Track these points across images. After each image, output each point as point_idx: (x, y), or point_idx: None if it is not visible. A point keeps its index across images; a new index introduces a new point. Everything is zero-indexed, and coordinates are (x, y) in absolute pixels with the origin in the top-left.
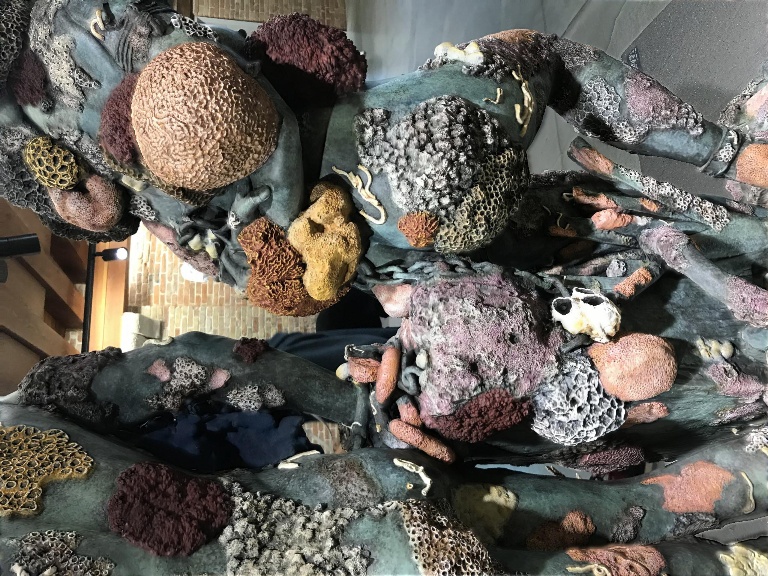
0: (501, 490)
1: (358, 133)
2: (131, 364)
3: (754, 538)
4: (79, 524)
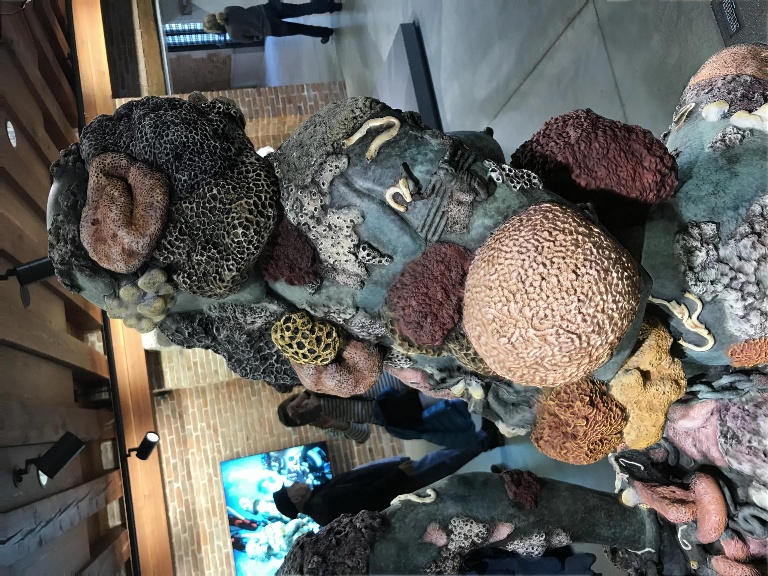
0: None
1: (684, 256)
2: (403, 535)
3: None
4: None
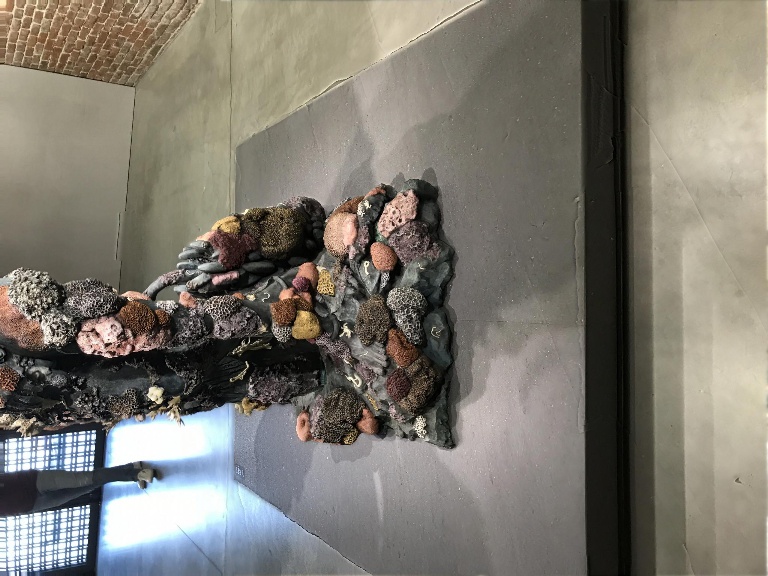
0: None
1: None
2: None
3: (402, 535)
4: None
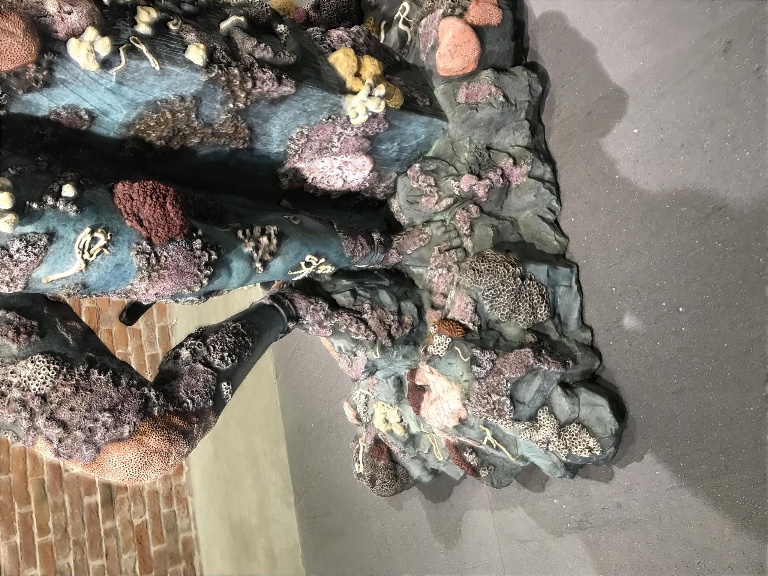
0: None
1: None
2: None
3: None
4: None
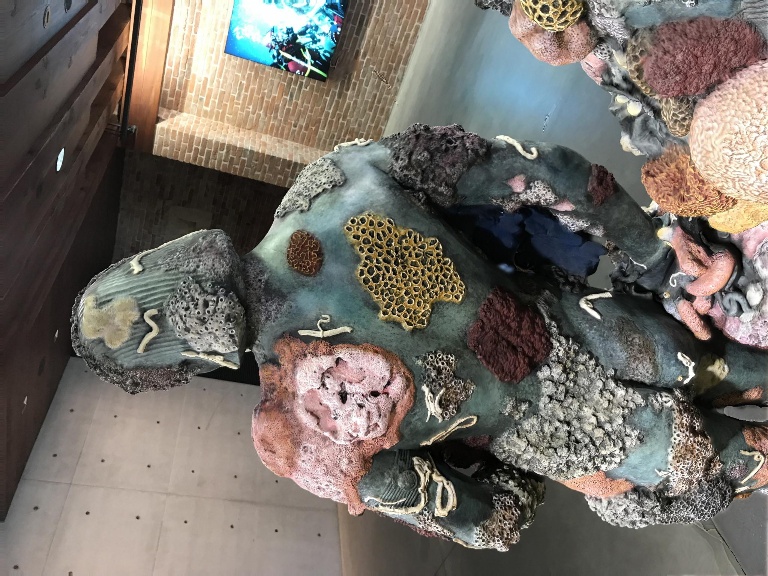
0: (722, 363)
1: None
2: (495, 171)
3: None
4: (450, 340)
